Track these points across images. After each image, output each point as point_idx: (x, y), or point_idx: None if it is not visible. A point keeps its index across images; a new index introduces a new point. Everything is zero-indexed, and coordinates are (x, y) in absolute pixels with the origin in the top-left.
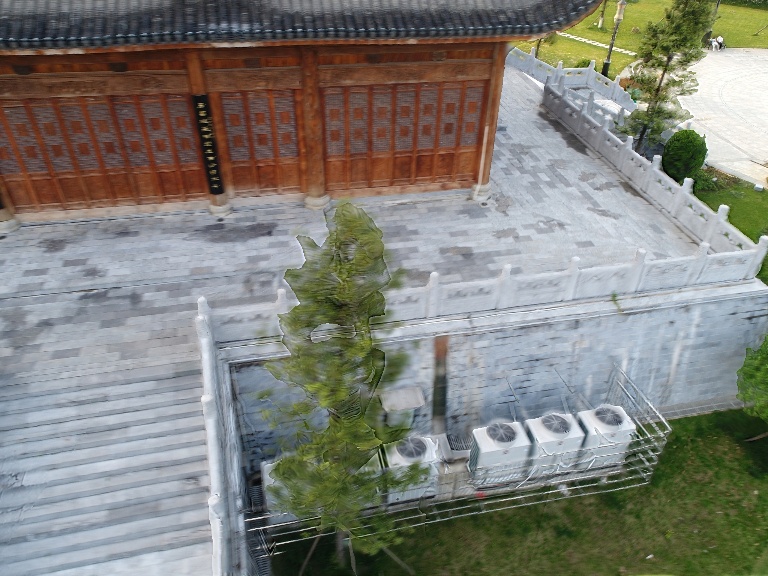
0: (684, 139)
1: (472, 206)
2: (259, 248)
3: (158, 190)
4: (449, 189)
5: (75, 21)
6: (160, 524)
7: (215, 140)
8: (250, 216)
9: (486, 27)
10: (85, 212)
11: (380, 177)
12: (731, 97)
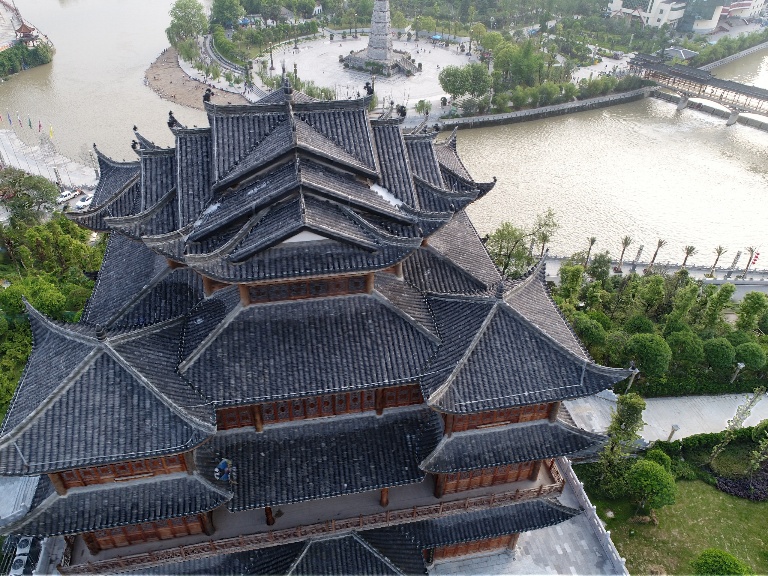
0: None
1: None
2: None
3: None
4: None
5: None
6: (18, 508)
7: None
8: None
9: None
10: None
11: None
12: None
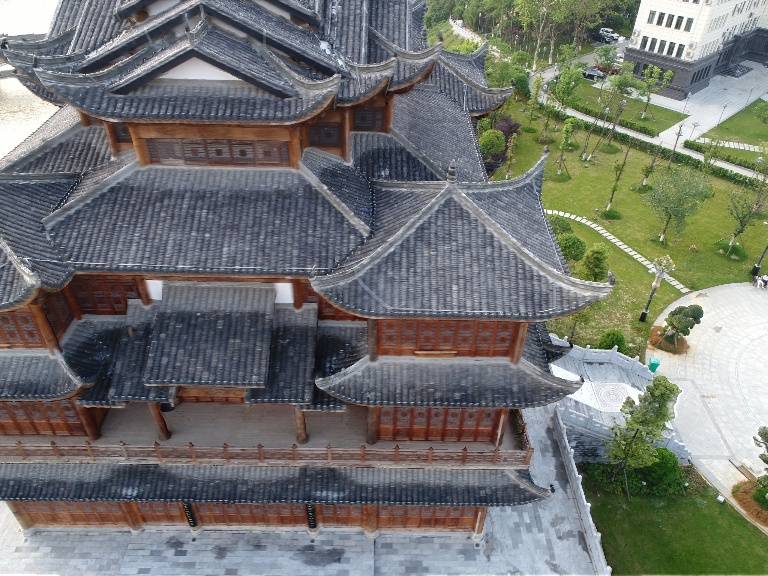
0: (660, 459)
1: (469, 546)
2: (331, 575)
3: (280, 522)
4: (456, 531)
5: (250, 486)
6: None
7: (315, 508)
8: (330, 540)
9: (470, 503)
10: (238, 527)
11: (411, 524)
12: (746, 366)
